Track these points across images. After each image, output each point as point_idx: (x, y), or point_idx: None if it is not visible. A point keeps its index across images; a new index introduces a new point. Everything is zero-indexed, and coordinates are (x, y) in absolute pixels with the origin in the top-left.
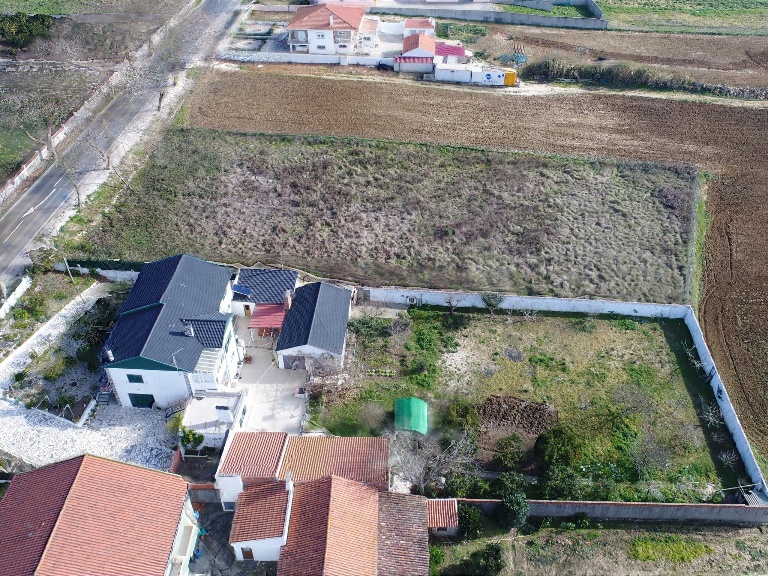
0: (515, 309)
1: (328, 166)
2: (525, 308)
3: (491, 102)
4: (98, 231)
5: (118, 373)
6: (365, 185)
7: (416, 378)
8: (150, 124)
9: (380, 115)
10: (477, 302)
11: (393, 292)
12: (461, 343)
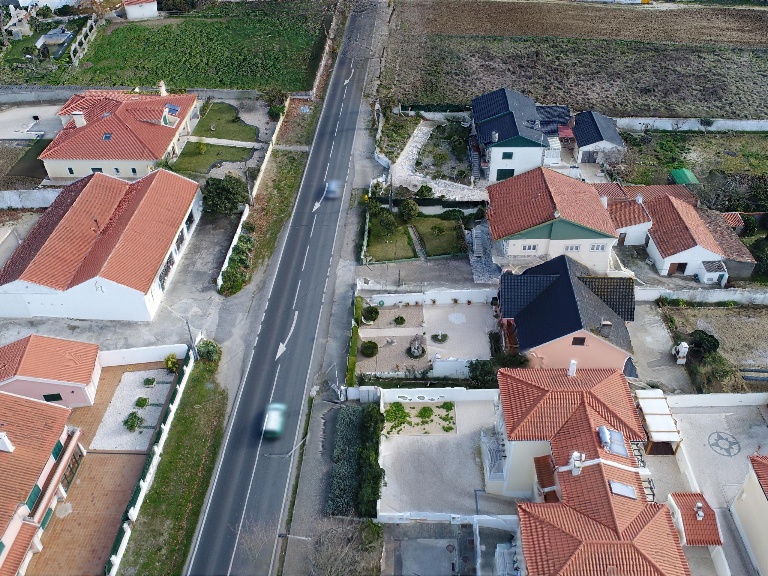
0: (719, 130)
1: (539, 55)
2: (727, 129)
3: (637, 14)
4: (399, 94)
5: (497, 152)
6: (573, 65)
7: (672, 165)
8: (389, 31)
9: (559, 23)
10: (693, 126)
11: (634, 121)
12: (691, 148)
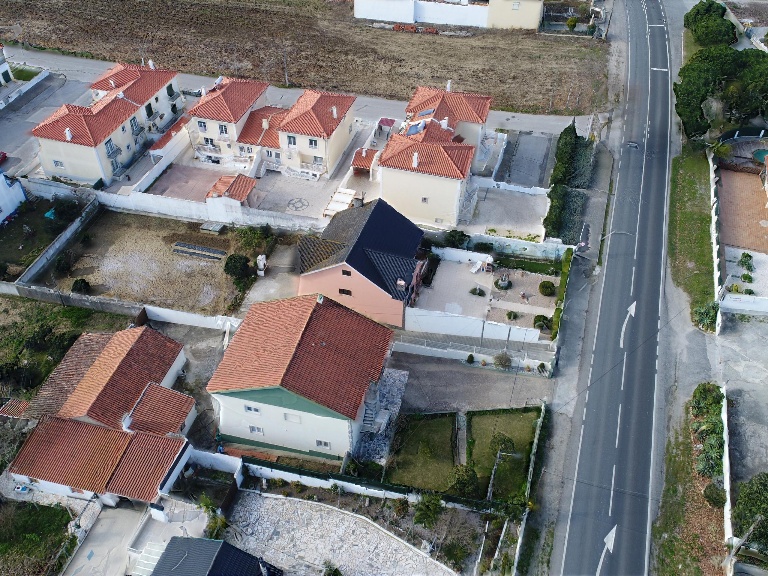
0: None
1: None
2: None
3: None
4: None
5: None
6: None
7: None
8: None
9: None
10: None
11: None
12: None
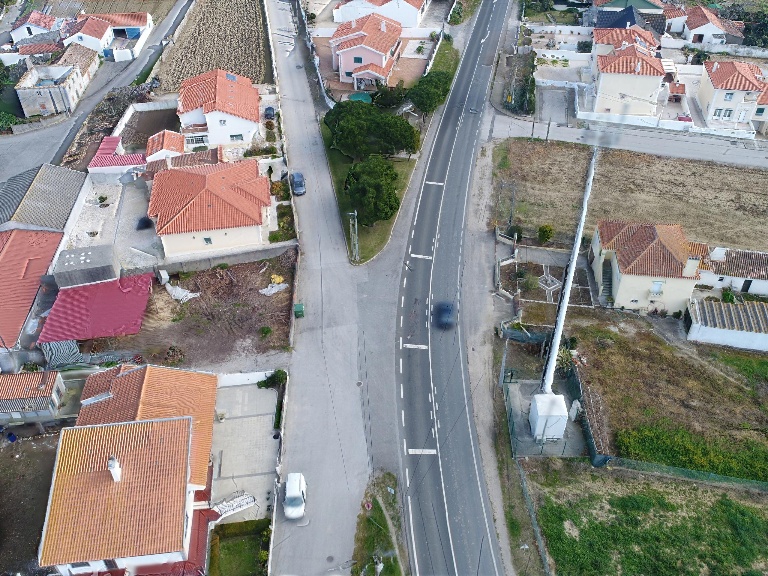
0: None
1: None
2: None
3: None
4: None
5: None
6: None
7: None
8: None
9: None
10: None
11: None
12: (727, 1)
